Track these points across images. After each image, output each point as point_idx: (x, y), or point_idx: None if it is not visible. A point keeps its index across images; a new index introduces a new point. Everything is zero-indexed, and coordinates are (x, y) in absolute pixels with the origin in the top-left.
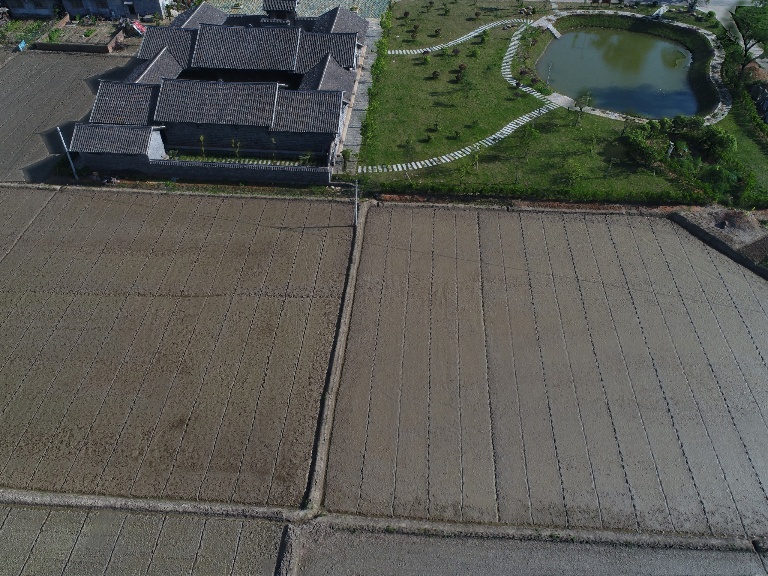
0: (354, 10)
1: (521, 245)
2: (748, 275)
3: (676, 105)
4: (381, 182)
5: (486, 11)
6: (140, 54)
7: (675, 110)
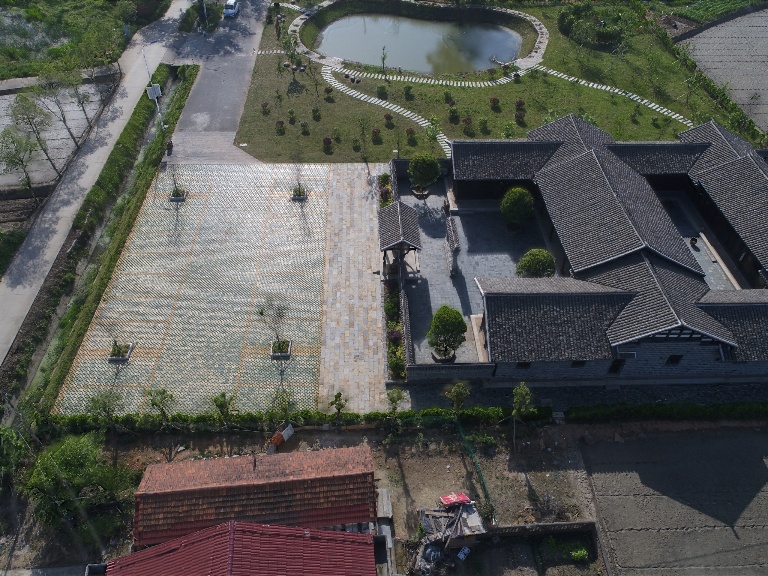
0: (304, 191)
1: (760, 90)
2: (711, 31)
3: (483, 30)
4: (760, 138)
5: (303, 89)
6: (729, 341)
7: (494, 31)
